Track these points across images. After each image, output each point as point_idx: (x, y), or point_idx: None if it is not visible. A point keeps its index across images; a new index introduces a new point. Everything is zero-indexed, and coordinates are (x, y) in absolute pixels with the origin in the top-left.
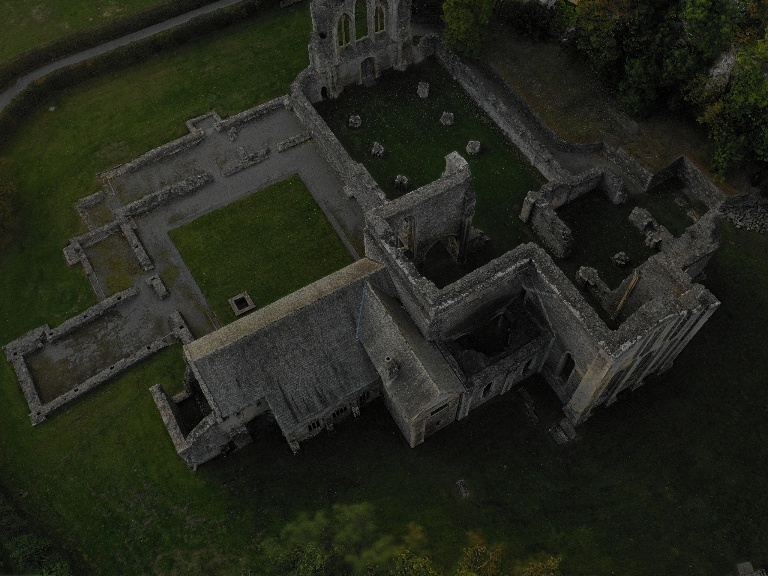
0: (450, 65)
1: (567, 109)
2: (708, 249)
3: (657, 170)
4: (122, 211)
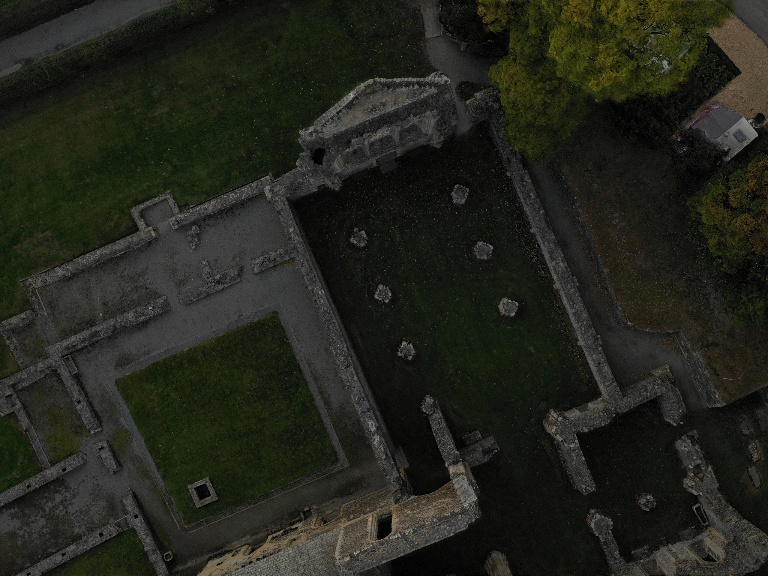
0: (506, 153)
1: (648, 273)
2: (745, 569)
3: (733, 399)
4: (57, 351)
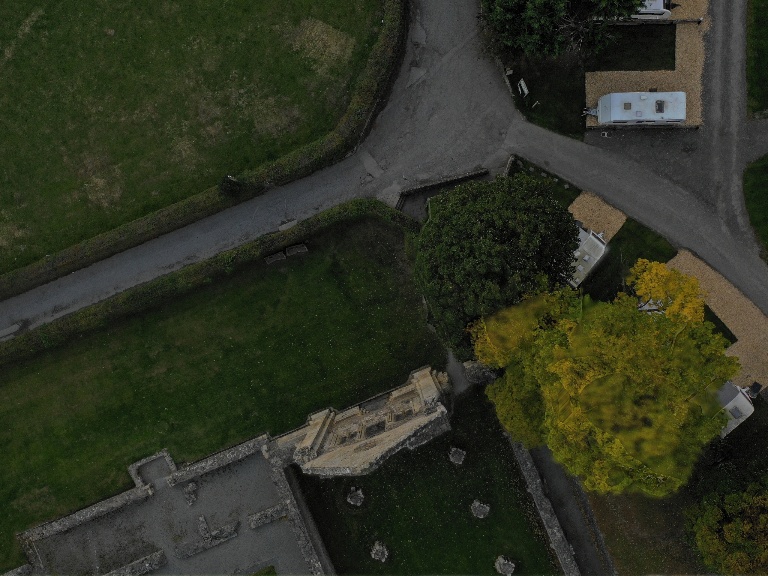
0: None
1: (644, 541)
2: None
3: None
4: None
